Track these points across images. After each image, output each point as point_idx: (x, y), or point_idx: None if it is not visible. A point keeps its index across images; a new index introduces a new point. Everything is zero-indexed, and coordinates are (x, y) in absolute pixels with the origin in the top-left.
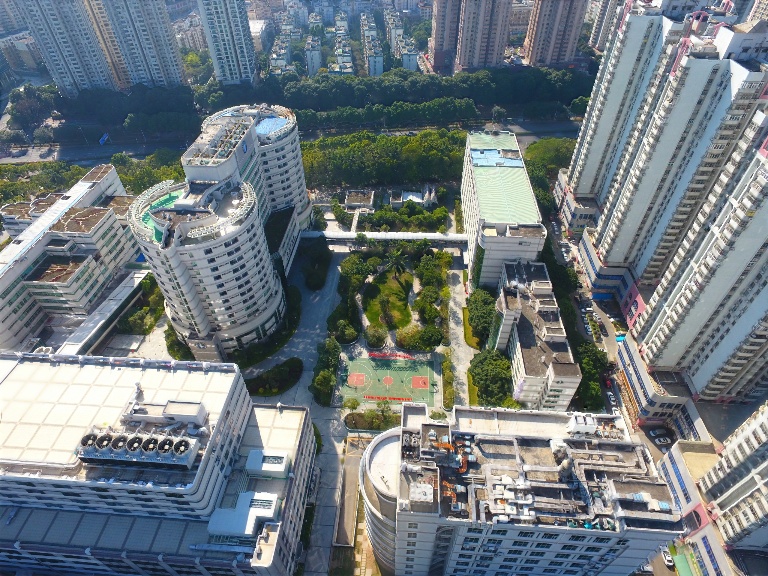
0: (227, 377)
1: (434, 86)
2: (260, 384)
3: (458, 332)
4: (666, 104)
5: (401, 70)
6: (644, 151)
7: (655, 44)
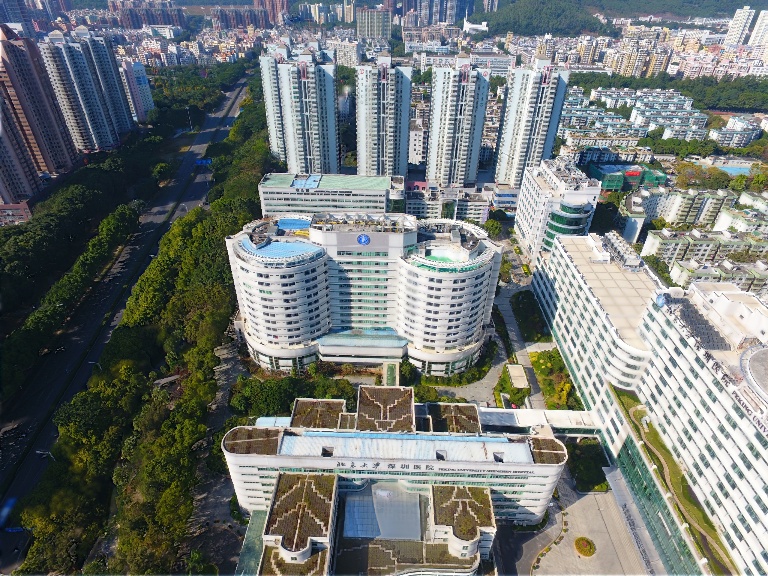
0: (562, 240)
1: (64, 220)
2: (497, 316)
3: None
4: (393, 92)
5: (6, 229)
6: (390, 118)
7: (323, 80)
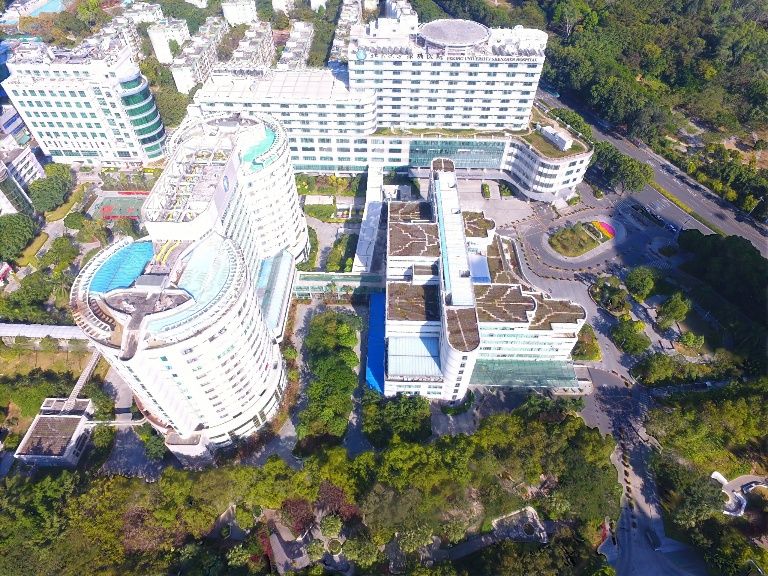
0: None
1: None
2: None
3: (49, 244)
4: None
5: None
6: None
7: None
